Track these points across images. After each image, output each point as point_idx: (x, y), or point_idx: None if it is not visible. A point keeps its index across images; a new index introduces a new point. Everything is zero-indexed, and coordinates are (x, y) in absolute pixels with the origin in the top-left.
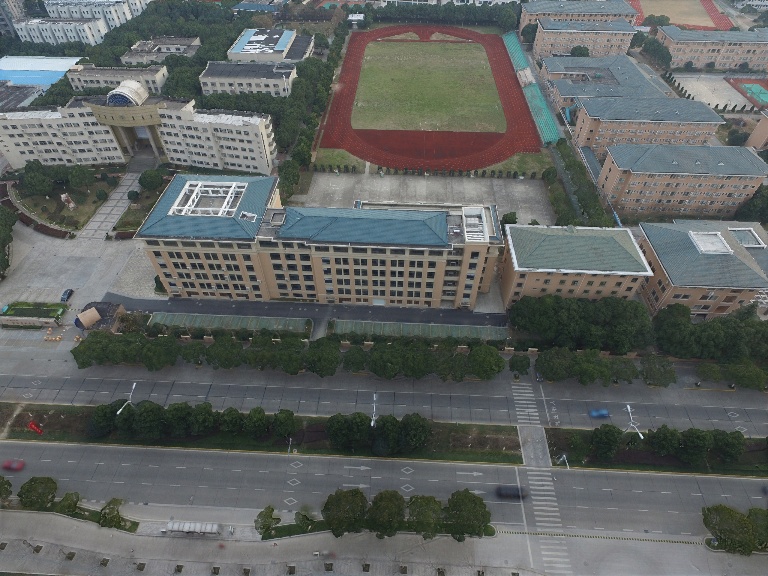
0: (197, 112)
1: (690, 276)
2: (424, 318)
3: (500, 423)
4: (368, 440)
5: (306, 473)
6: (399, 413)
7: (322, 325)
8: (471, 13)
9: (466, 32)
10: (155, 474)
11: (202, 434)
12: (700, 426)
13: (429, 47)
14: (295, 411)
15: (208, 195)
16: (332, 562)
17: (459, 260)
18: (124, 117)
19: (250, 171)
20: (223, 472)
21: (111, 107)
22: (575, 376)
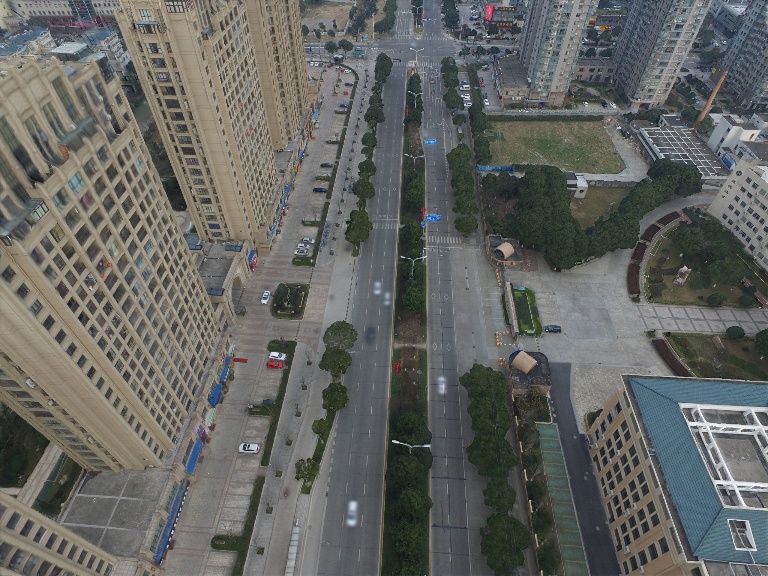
0: None
1: None
2: None
3: None
4: None
5: None
6: None
7: None
8: None
9: None
10: (356, 494)
11: None
12: None
13: None
14: None
15: (761, 447)
16: None
17: None
18: None
19: None
20: (355, 575)
21: None
22: None
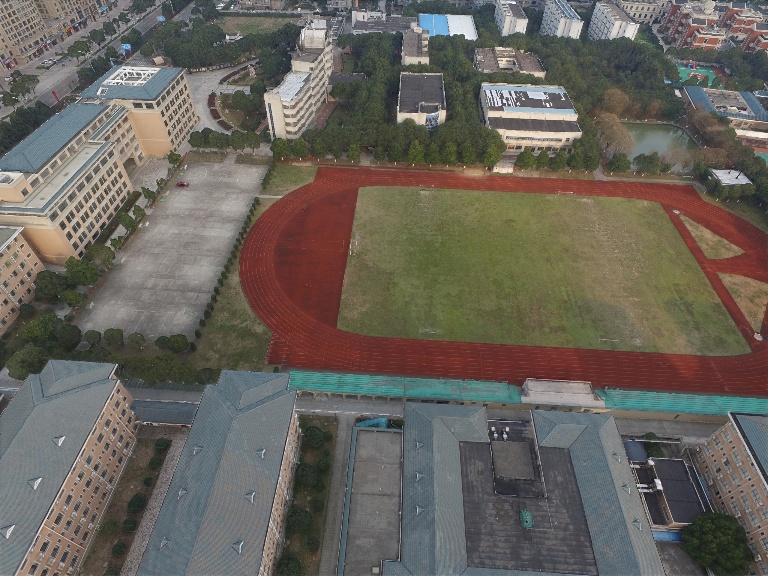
0: None
1: None
2: None
3: None
4: None
5: None
6: None
7: None
8: None
9: None
10: None
11: None
12: None
13: (673, 268)
14: None
15: None
16: None
17: None
18: None
19: None
20: None
21: None
22: None
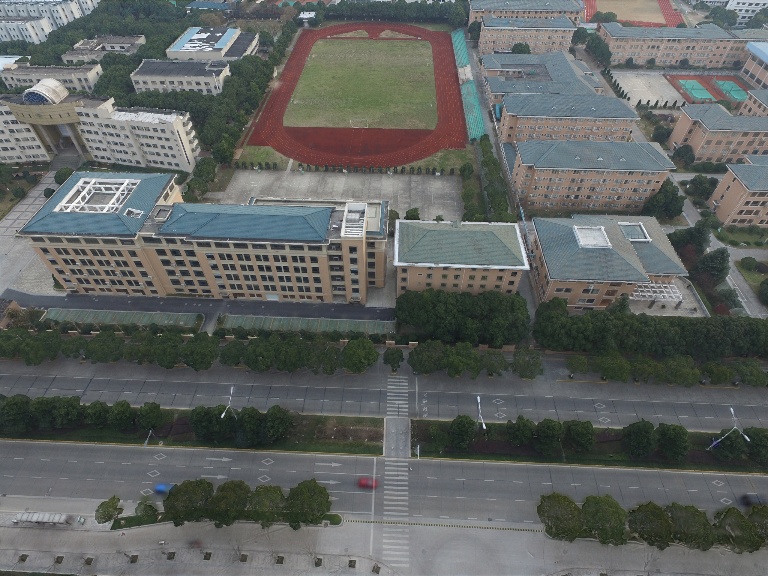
0: (117, 110)
1: (567, 270)
2: (315, 313)
3: (368, 415)
4: (231, 432)
5: (167, 465)
6: (271, 406)
7: (213, 320)
8: (422, 10)
9: (416, 29)
10: (19, 466)
11: (68, 427)
12: (565, 417)
13: (376, 45)
14: (169, 404)
15: (101, 192)
16: (175, 551)
17: (341, 255)
18: (41, 115)
19: (172, 168)
20: (86, 464)
21: (27, 105)
22: (444, 369)
